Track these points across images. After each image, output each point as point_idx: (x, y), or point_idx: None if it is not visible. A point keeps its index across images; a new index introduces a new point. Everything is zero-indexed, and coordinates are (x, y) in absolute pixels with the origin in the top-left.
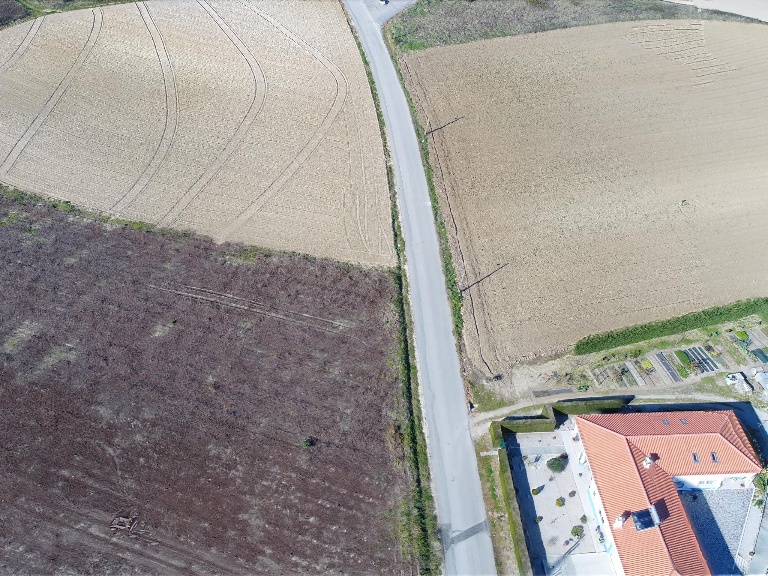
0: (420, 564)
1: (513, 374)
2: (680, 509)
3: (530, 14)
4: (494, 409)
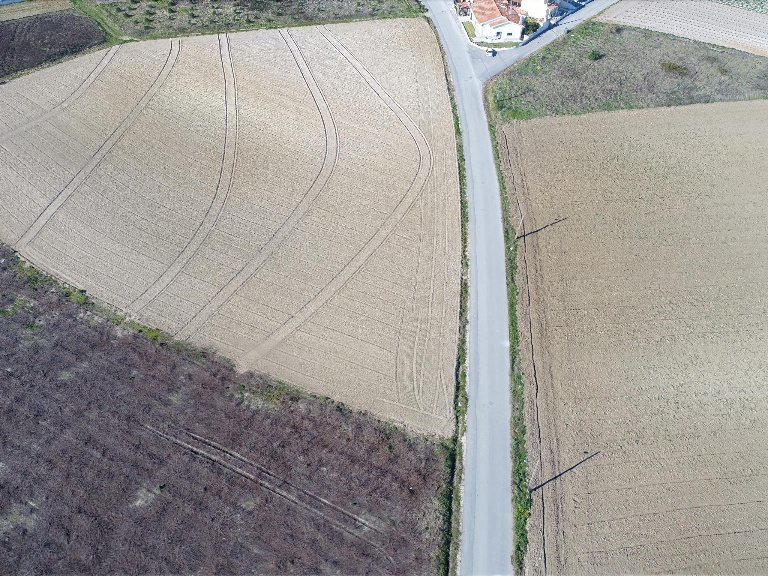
0: None
1: None
2: None
3: (664, 82)
4: None
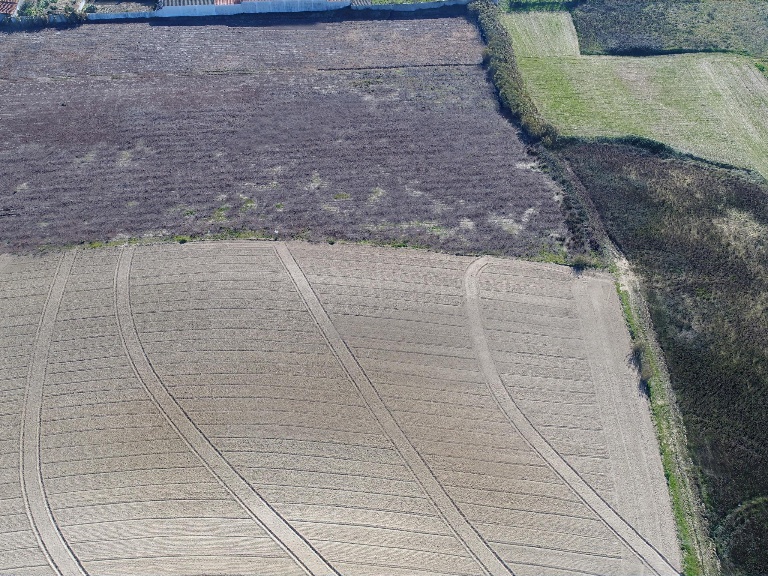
0: None
1: None
2: None
3: None
4: None
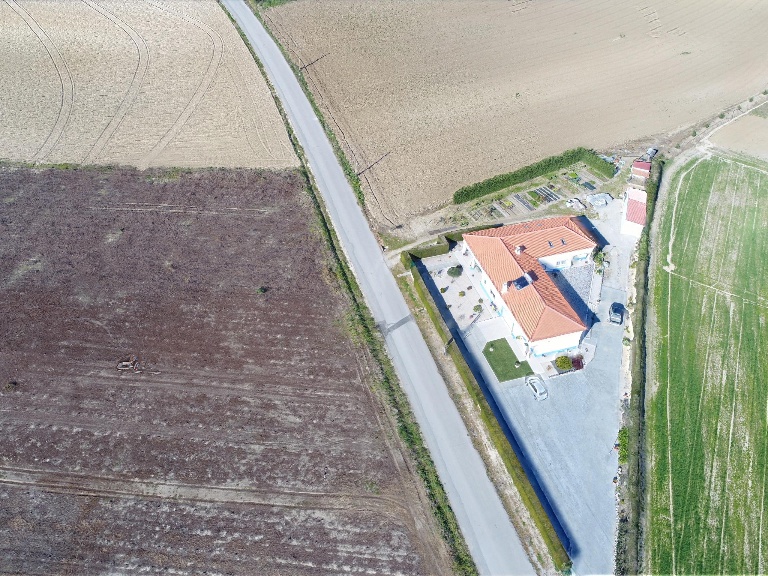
0: (369, 347)
1: (410, 223)
2: (545, 276)
3: None
4: (401, 247)
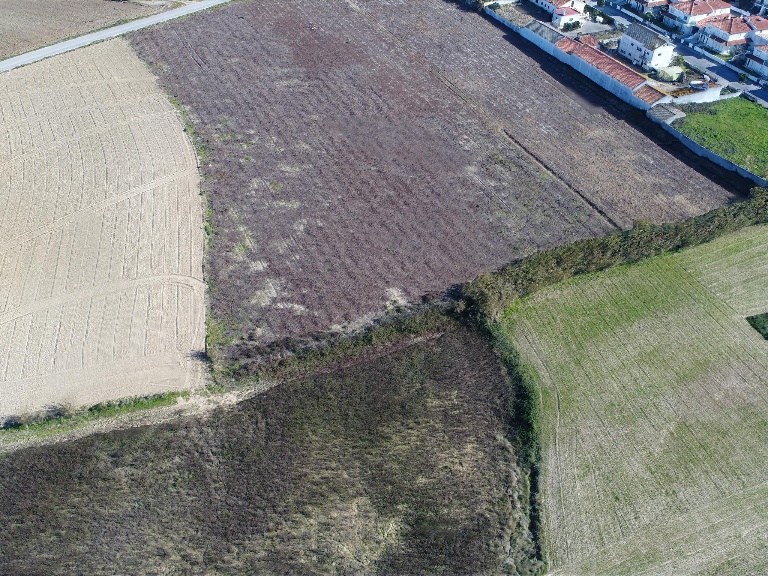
0: None
1: None
2: None
3: None
4: (181, 2)
